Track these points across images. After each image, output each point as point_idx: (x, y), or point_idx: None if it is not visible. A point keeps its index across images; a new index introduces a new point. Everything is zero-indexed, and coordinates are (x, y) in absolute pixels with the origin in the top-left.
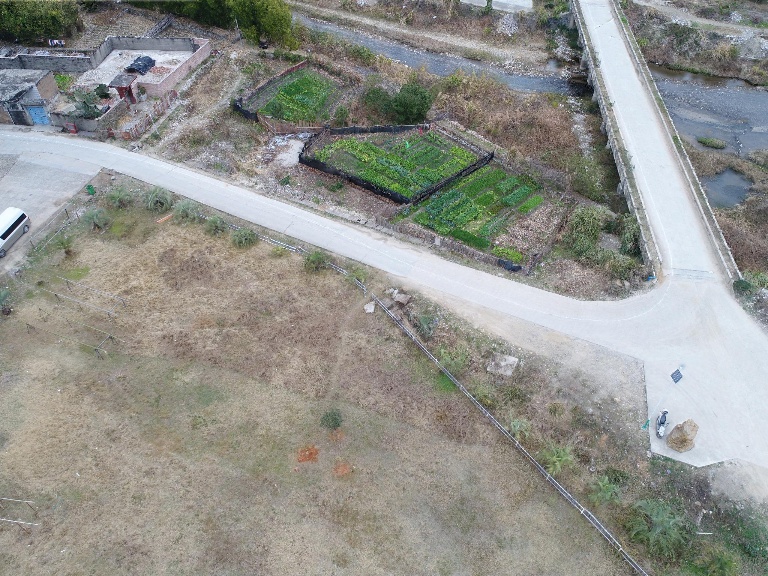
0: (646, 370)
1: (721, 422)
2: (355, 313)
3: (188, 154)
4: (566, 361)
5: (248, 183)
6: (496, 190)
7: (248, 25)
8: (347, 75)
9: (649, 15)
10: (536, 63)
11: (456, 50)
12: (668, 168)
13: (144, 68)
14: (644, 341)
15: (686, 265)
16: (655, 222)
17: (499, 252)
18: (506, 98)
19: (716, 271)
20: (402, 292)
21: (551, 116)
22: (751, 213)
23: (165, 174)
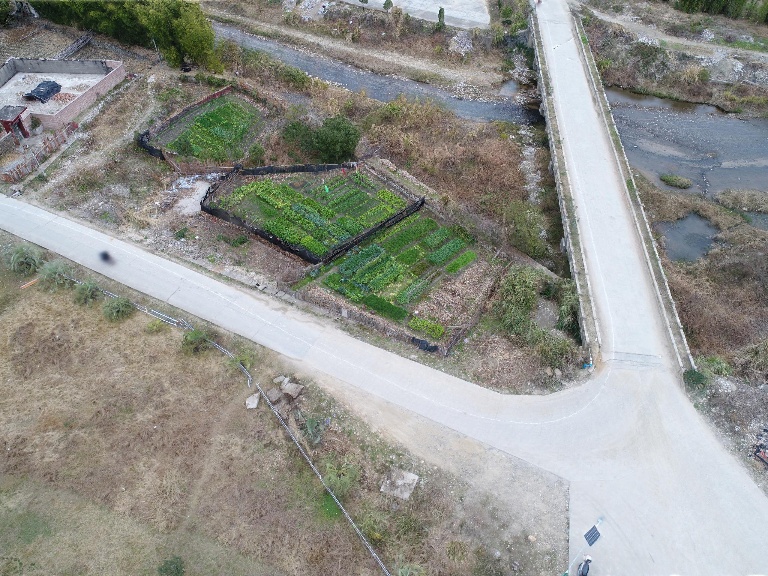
0: (571, 494)
1: (658, 569)
2: (234, 409)
3: (74, 200)
4: (476, 481)
5: (137, 237)
6: (423, 244)
7: (167, 46)
8: (271, 104)
9: (614, 33)
10: (489, 86)
11: (403, 71)
12: (619, 219)
13: (46, 95)
14: (572, 452)
15: (630, 347)
16: (598, 290)
17: (417, 325)
18: (450, 128)
19: (665, 355)
20: (294, 380)
21: (498, 150)
22: (714, 269)
23: (42, 226)
